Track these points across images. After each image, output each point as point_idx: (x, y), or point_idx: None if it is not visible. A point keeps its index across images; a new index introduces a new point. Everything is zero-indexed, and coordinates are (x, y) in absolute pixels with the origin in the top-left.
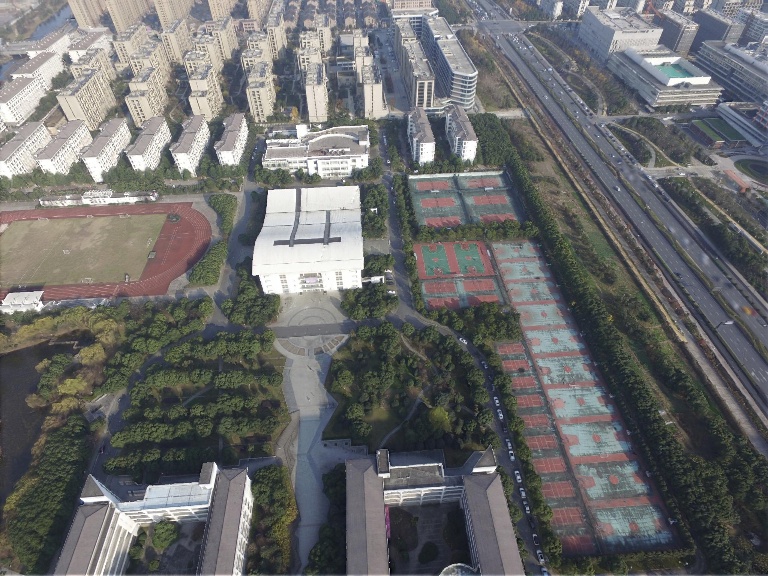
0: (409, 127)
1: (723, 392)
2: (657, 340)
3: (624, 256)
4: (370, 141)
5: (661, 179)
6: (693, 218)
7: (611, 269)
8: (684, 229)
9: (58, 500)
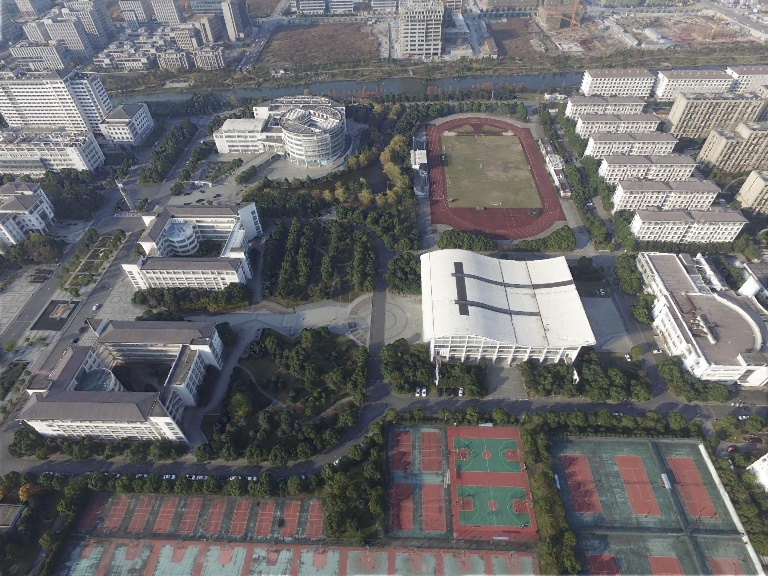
0: None
1: None
2: None
3: None
4: None
5: None
6: None
7: None
8: None
9: (262, 206)
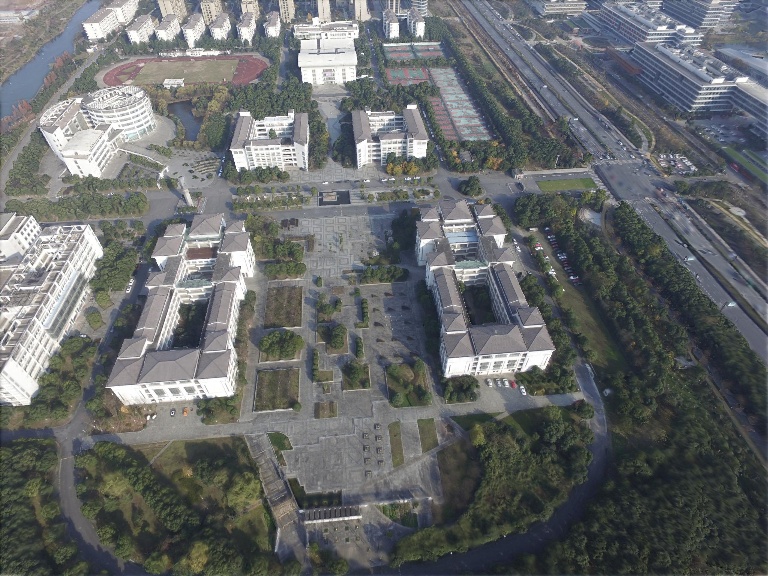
0: (384, 22)
1: (534, 108)
2: (507, 92)
3: (502, 71)
4: (359, 29)
5: (535, 45)
6: (547, 59)
7: (492, 73)
8: (540, 63)
9: (223, 128)
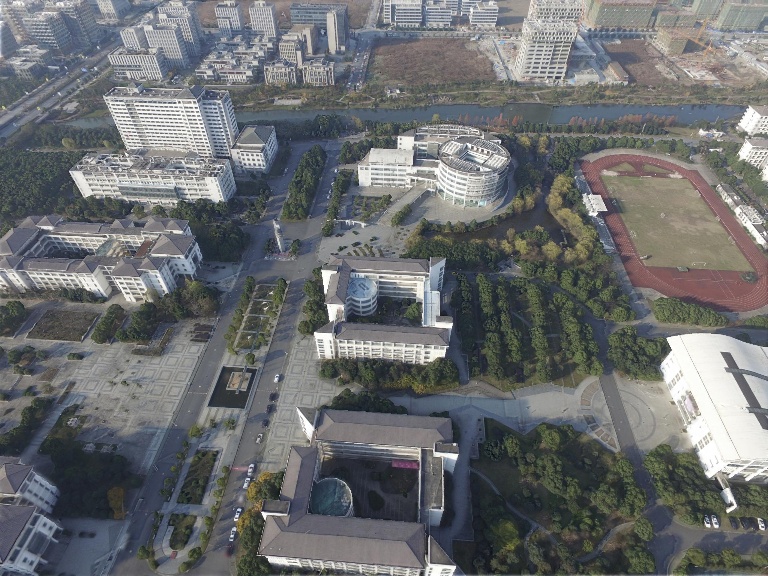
0: None
1: None
2: None
3: None
4: None
5: None
6: None
7: None
8: None
9: None
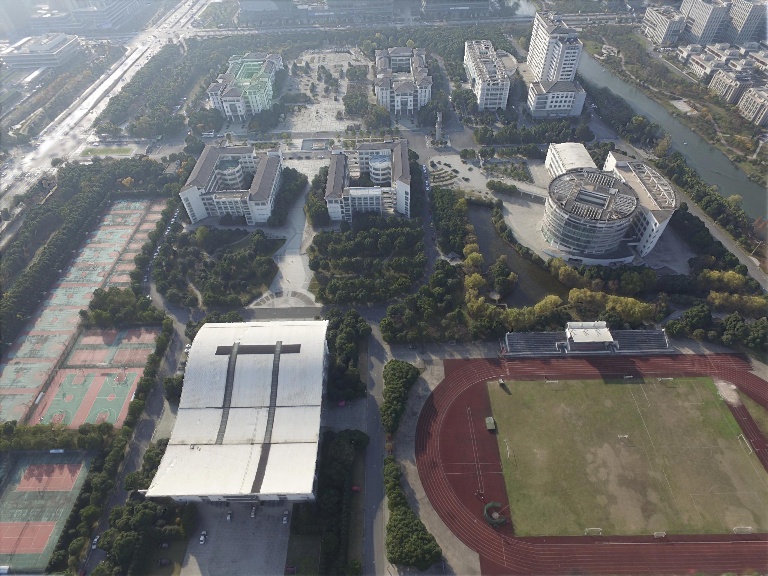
0: None
1: None
2: None
3: None
4: None
5: None
6: None
7: None
8: None
9: None
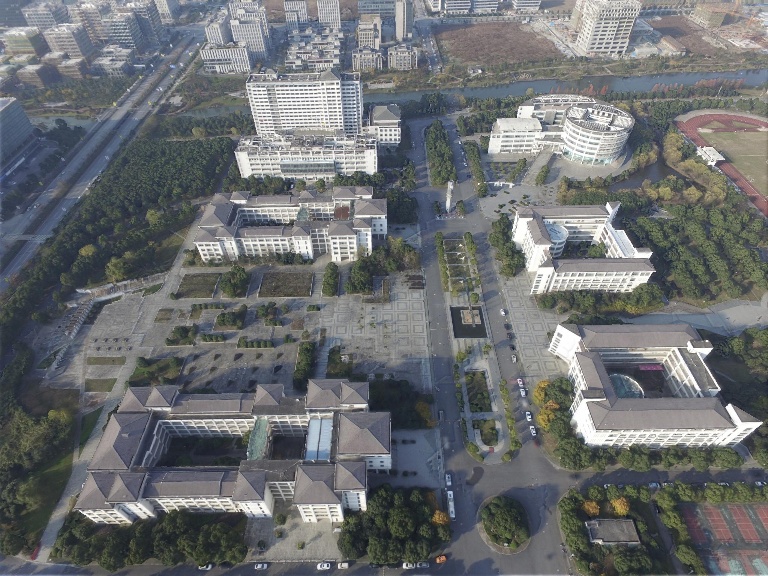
0: None
1: None
2: None
3: None
4: None
5: None
6: None
7: None
8: None
9: None
